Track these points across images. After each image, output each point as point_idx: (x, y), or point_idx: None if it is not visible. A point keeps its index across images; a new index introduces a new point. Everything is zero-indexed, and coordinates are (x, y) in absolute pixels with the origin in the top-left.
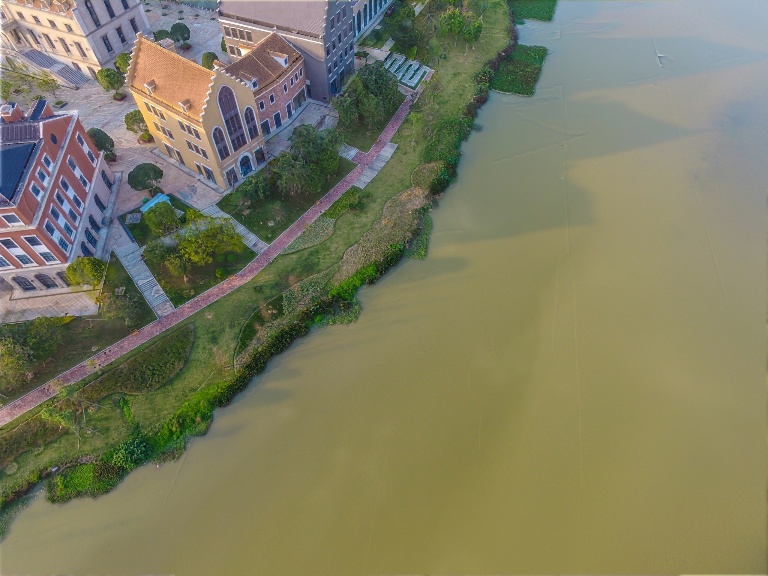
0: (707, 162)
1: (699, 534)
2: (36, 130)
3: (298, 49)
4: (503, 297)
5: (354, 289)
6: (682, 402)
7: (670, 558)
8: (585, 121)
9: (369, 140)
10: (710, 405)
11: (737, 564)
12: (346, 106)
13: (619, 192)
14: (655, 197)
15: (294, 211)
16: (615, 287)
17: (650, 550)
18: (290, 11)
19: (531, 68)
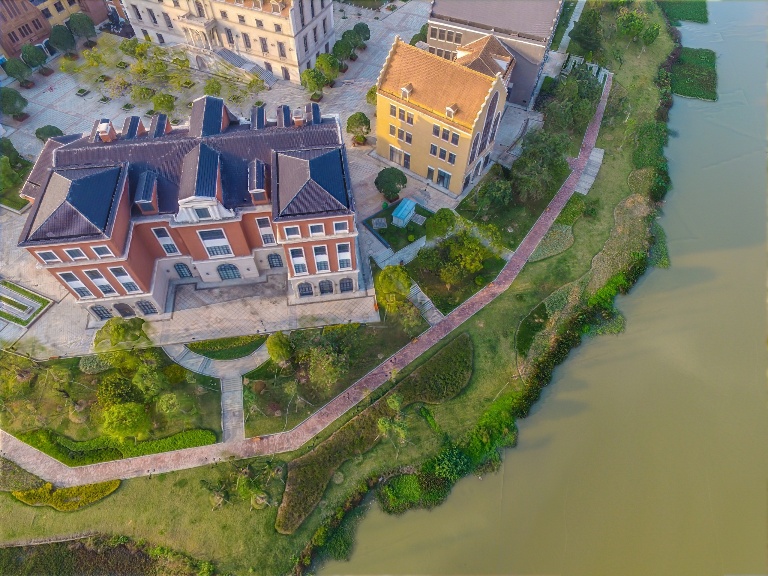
0: None
1: None
2: (335, 135)
3: (512, 52)
4: (764, 309)
5: (611, 298)
6: None
7: None
8: None
9: (575, 145)
10: None
11: None
12: (567, 111)
13: None
14: None
15: (528, 217)
16: None
17: None
18: (514, 13)
19: (706, 72)
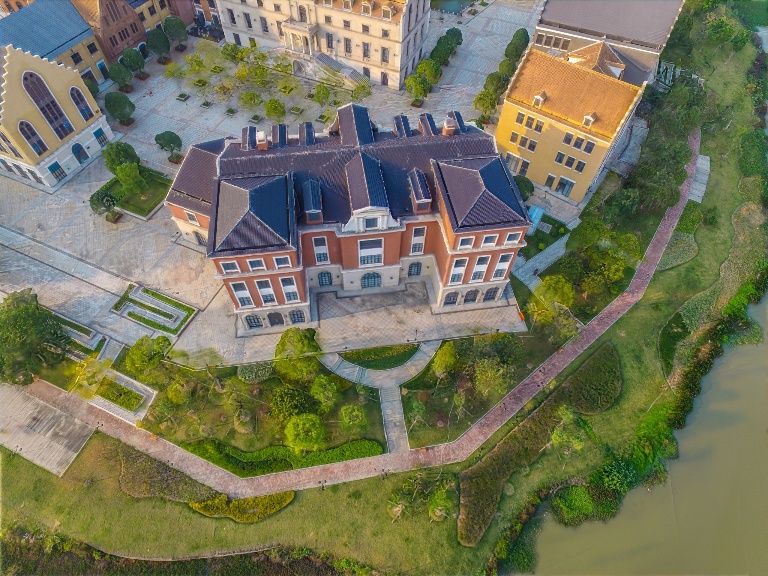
0: None
1: None
2: (491, 144)
3: (623, 59)
4: None
5: (744, 308)
6: None
7: None
8: None
9: None
10: None
11: None
12: None
13: None
14: None
15: (648, 225)
16: None
17: None
18: (628, 20)
19: None
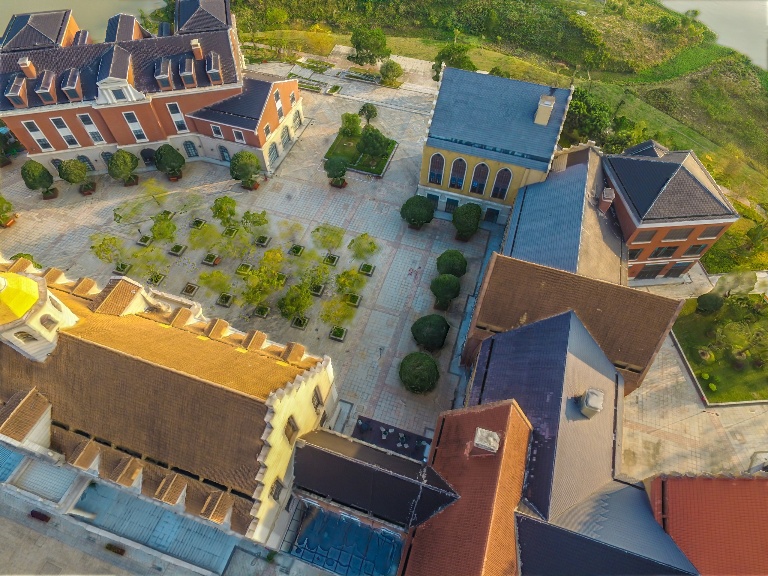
0: None
1: None
2: None
3: None
4: None
5: None
6: None
7: None
8: None
9: None
10: None
11: None
12: None
13: None
14: None
15: None
16: None
17: None
18: None
19: None
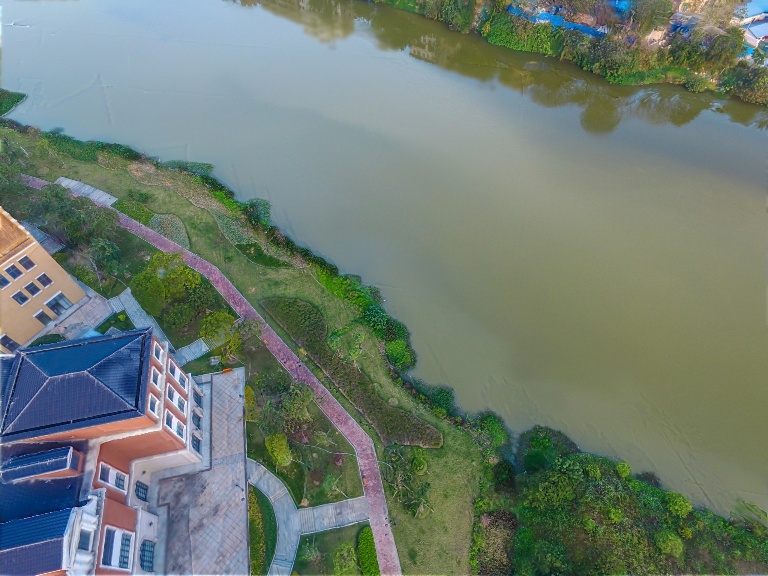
0: (157, 30)
1: (403, 80)
2: None
3: None
4: (258, 128)
5: None
6: (338, 73)
7: (413, 92)
8: (82, 72)
9: None
10: (339, 66)
11: (413, 74)
12: (6, 180)
13: (172, 70)
14: (184, 56)
15: None
16: (258, 83)
17: (411, 95)
18: None
19: None
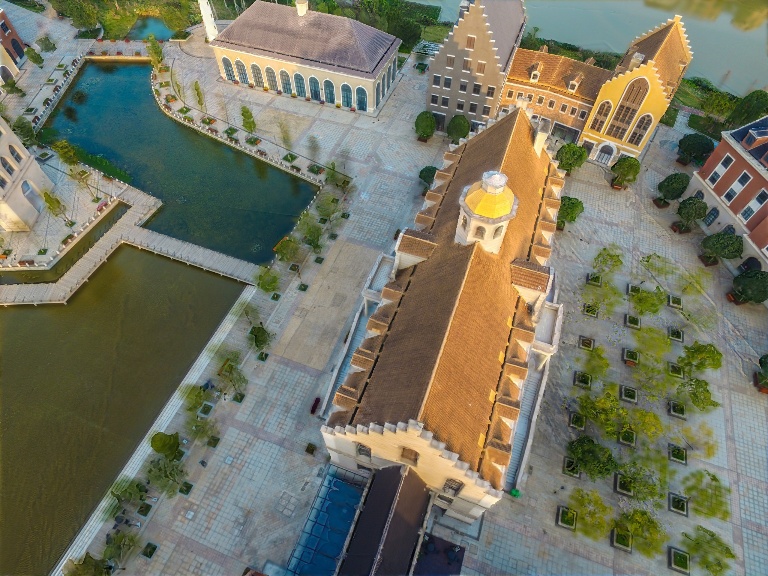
0: None
1: None
2: None
3: None
4: None
5: None
6: None
7: None
8: None
9: None
10: None
11: None
12: None
13: None
14: None
15: None
16: None
17: None
18: None
19: (401, 3)
